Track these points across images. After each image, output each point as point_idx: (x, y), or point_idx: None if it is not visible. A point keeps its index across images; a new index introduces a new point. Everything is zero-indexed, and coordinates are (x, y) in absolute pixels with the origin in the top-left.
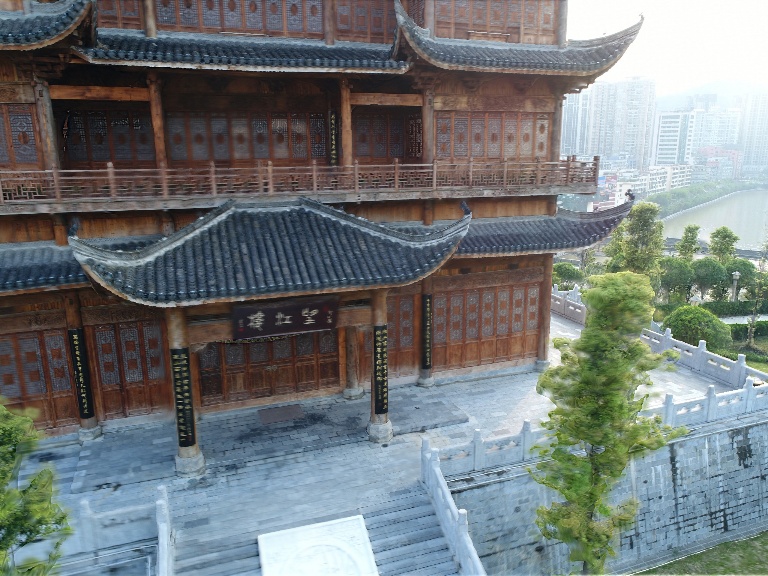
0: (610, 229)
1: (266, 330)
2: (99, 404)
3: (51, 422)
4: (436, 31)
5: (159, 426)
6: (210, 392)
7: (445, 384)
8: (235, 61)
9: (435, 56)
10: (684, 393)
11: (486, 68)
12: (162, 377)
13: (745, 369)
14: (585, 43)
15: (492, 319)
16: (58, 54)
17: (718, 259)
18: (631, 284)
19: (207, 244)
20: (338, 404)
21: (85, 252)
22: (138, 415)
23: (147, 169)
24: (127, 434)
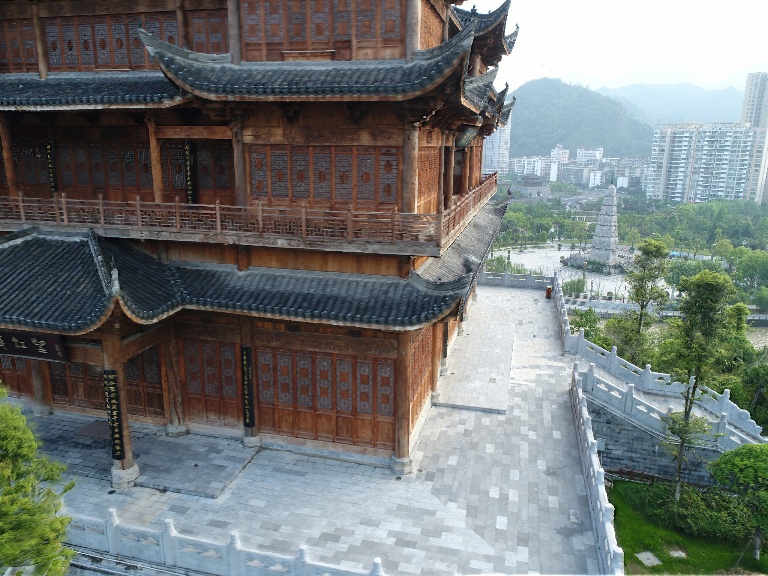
0: (441, 309)
1: (11, 350)
2: None
3: None
4: (246, 55)
5: (23, 410)
6: (59, 393)
7: (275, 449)
8: (19, 102)
9: (198, 86)
10: (511, 571)
11: (261, 97)
12: (25, 370)
13: (613, 575)
14: (428, 54)
15: (330, 390)
16: None
17: None
18: None
19: None
20: (151, 436)
21: None
22: (11, 396)
23: None
24: None
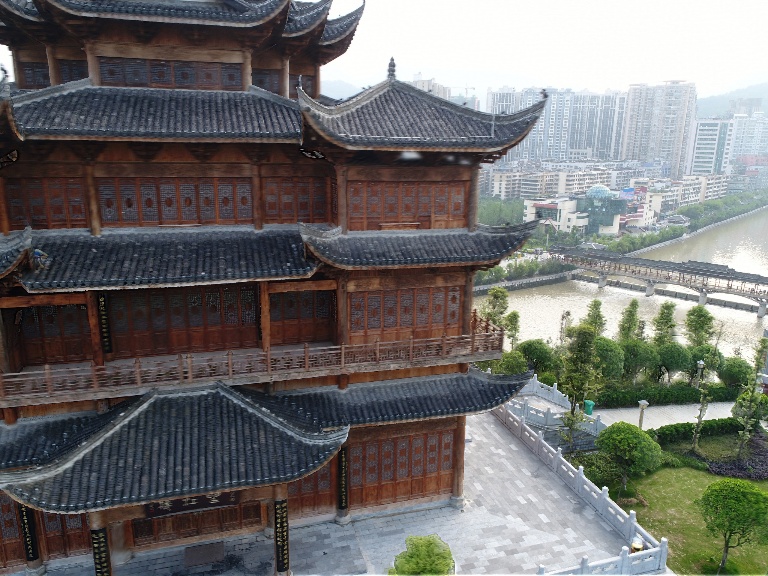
0: (512, 394)
1: (175, 510)
2: (43, 547)
3: (2, 563)
4: (349, 225)
5: None
6: (142, 534)
7: (362, 520)
8: (154, 281)
9: (339, 261)
10: (576, 545)
11: (389, 266)
12: None
13: (634, 526)
14: (491, 229)
15: (407, 463)
16: (2, 283)
17: (694, 336)
18: (432, 557)
19: (124, 441)
20: (257, 544)
21: (5, 480)
22: (78, 555)
23: (79, 368)
24: (67, 573)
